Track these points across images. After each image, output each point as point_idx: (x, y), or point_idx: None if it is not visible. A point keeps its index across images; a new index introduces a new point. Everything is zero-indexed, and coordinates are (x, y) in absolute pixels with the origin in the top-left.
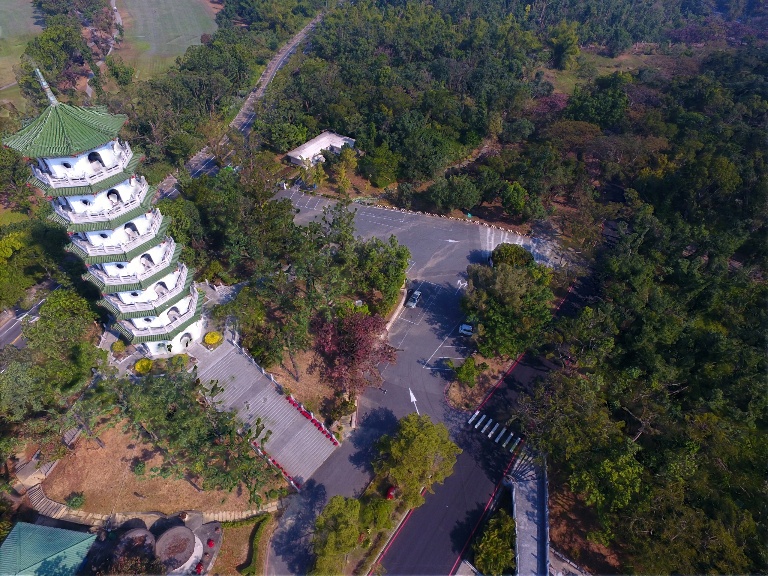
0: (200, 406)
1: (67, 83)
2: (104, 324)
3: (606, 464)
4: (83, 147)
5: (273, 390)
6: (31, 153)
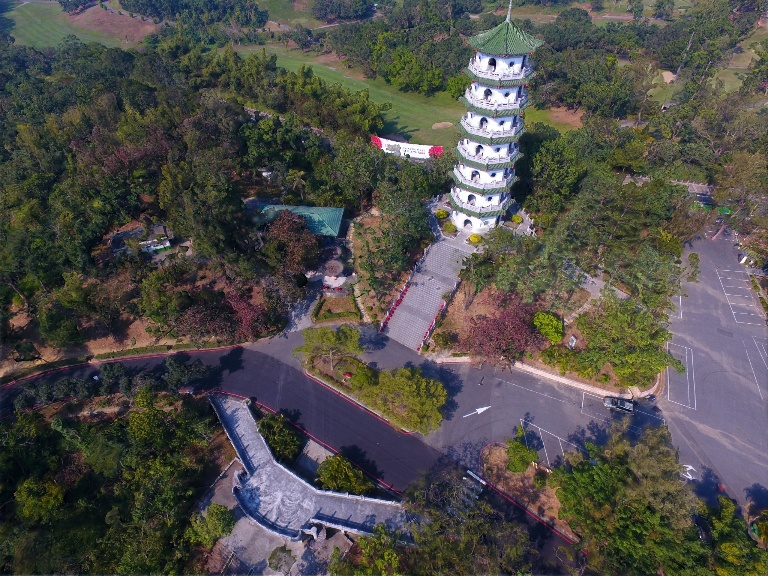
0: (423, 253)
1: (764, 82)
2: None
3: (391, 553)
4: (485, 50)
5: (448, 291)
6: (469, 41)
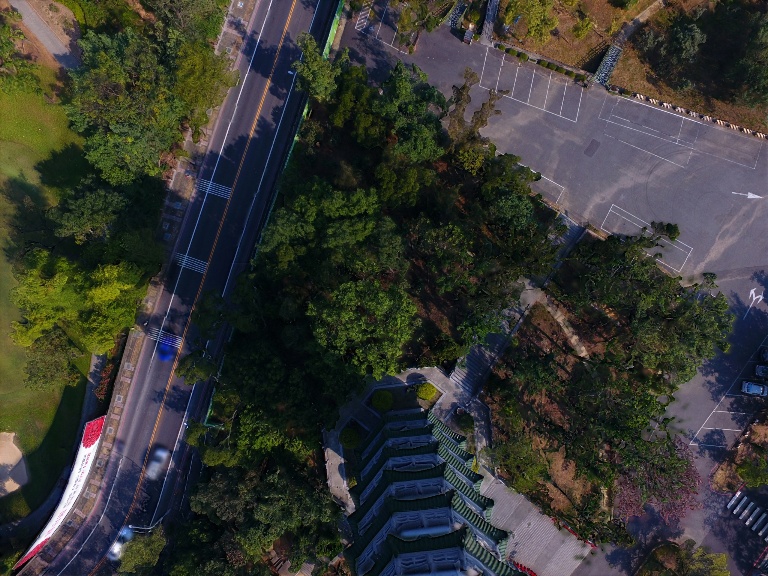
0: None
1: None
2: (322, 447)
3: None
4: None
5: (537, 513)
6: None
